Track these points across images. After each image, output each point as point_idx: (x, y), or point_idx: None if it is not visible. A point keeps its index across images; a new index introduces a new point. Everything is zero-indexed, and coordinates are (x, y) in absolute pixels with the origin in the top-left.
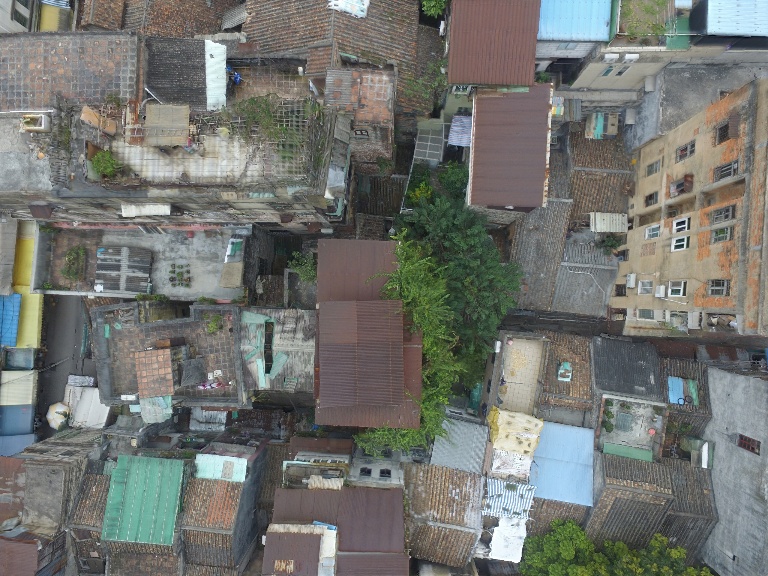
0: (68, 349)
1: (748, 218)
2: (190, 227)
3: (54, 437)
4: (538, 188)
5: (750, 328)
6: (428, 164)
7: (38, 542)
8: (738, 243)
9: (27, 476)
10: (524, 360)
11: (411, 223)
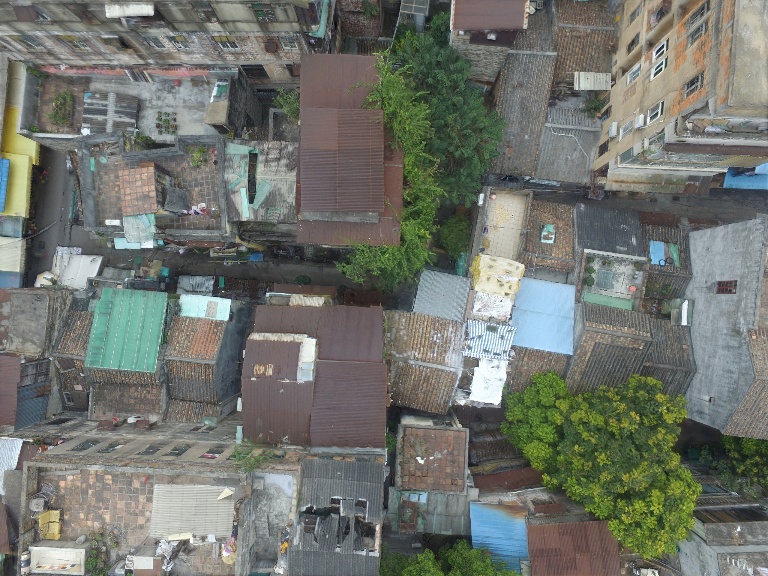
0: (57, 227)
1: (721, 2)
2: (177, 71)
3: None
4: (519, 10)
5: (721, 104)
6: (414, 24)
7: (21, 355)
8: (712, 31)
9: (12, 304)
10: (507, 215)
11: None
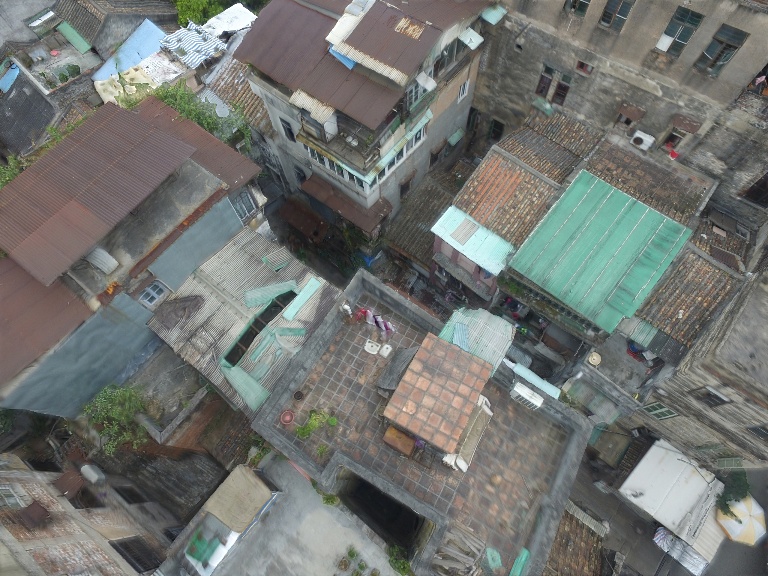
0: None
1: None
2: None
3: (742, 462)
4: None
5: None
6: None
7: None
8: None
9: None
10: None
11: (34, 413)
